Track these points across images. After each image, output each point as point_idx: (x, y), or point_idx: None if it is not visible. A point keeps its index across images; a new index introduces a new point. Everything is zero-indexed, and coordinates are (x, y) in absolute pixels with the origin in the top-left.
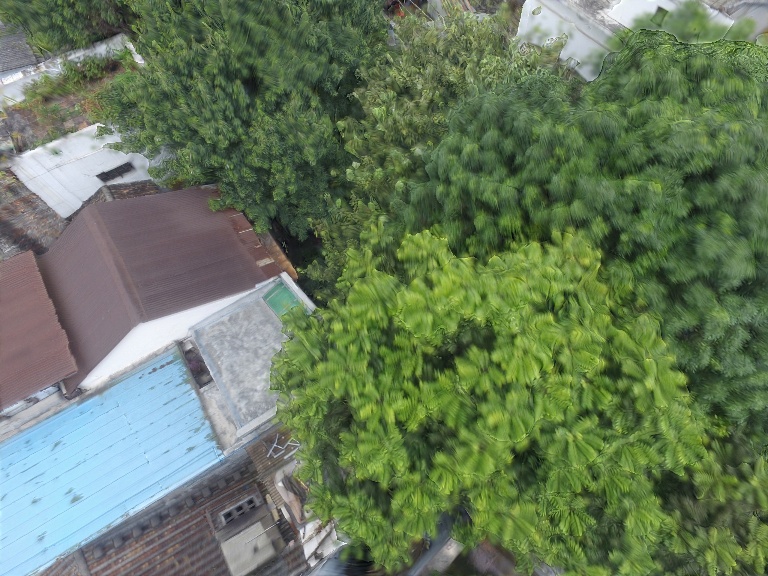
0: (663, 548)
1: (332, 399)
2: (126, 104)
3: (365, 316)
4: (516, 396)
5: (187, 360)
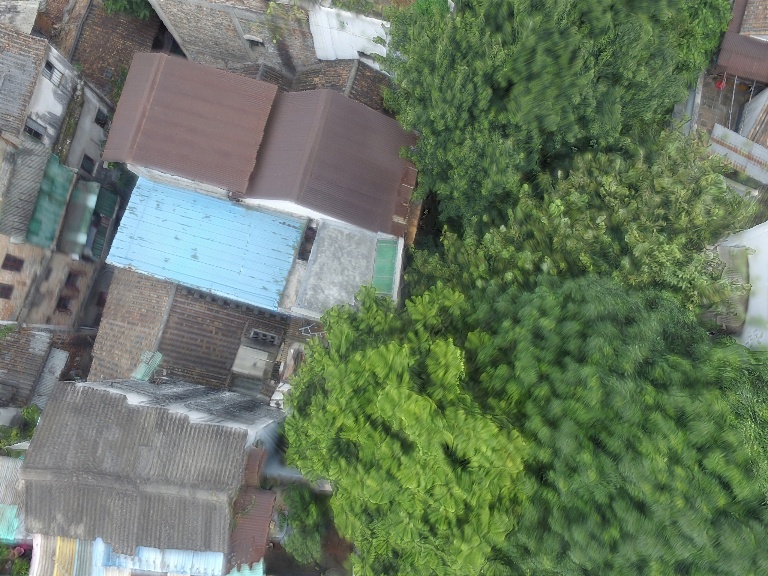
0: None
1: None
2: (409, 35)
3: (373, 368)
4: (390, 486)
5: (305, 234)
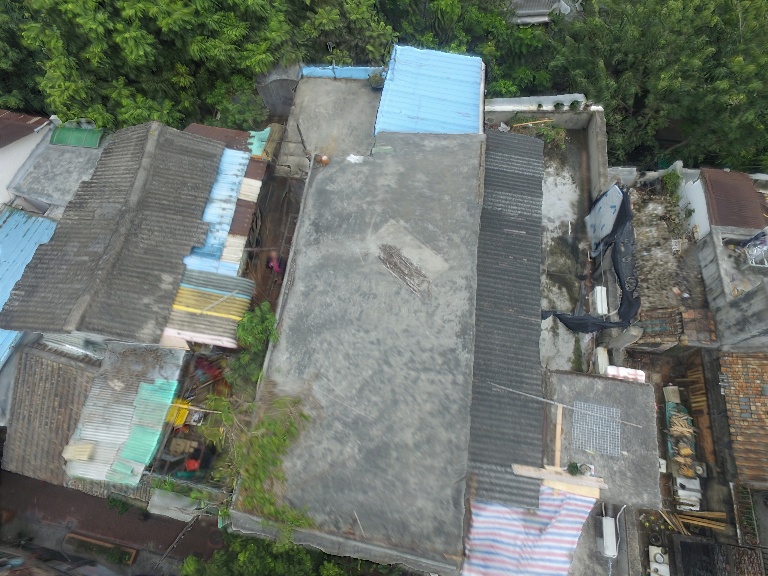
0: (313, 41)
1: (70, 44)
2: None
3: None
4: None
5: None
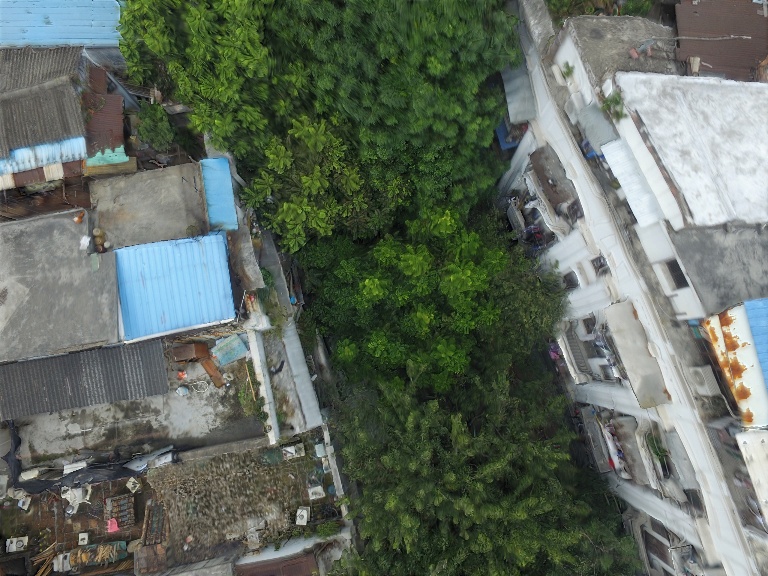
0: None
1: None
2: None
3: None
4: None
5: None
